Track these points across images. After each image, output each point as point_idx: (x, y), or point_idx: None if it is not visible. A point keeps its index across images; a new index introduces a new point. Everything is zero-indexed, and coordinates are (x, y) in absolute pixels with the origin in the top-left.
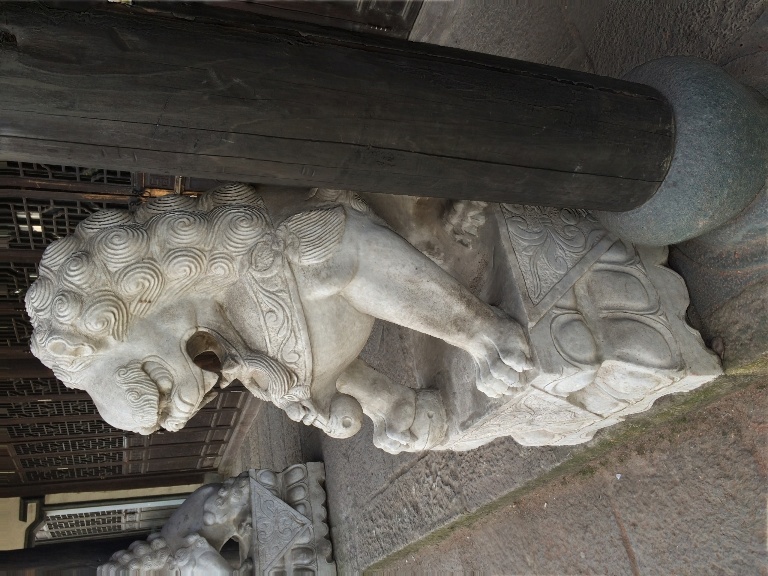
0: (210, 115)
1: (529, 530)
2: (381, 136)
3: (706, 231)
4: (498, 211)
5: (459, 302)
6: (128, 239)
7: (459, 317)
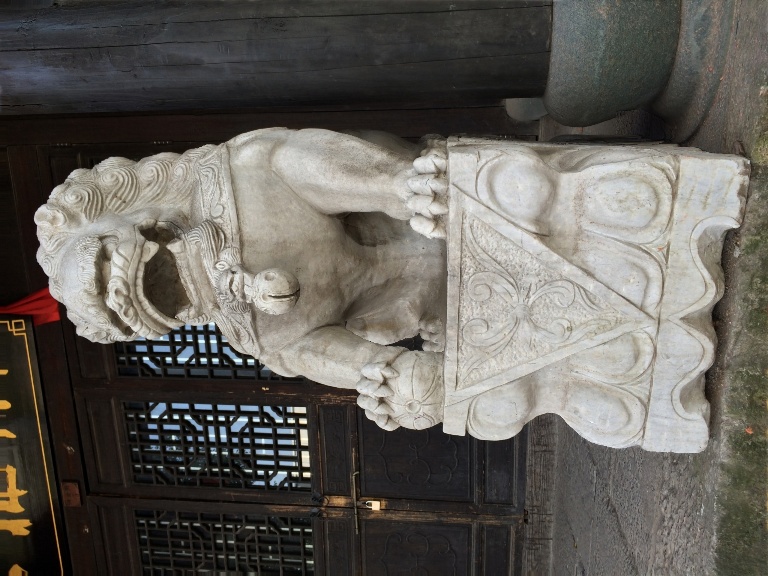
0: (154, 15)
1: None
2: (271, 10)
3: (631, 34)
4: None
5: (380, 152)
6: None
7: (381, 163)
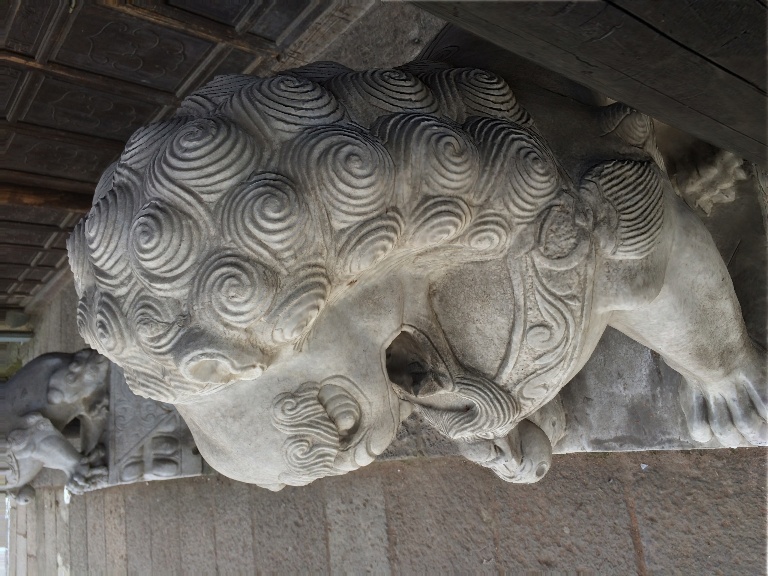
0: None
1: (494, 487)
2: None
3: None
4: (760, 191)
5: (739, 329)
6: (374, 166)
7: (728, 348)
